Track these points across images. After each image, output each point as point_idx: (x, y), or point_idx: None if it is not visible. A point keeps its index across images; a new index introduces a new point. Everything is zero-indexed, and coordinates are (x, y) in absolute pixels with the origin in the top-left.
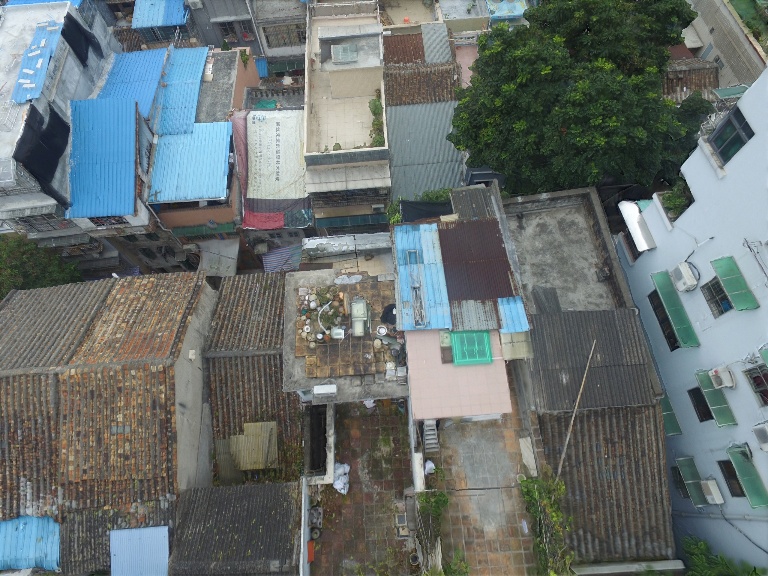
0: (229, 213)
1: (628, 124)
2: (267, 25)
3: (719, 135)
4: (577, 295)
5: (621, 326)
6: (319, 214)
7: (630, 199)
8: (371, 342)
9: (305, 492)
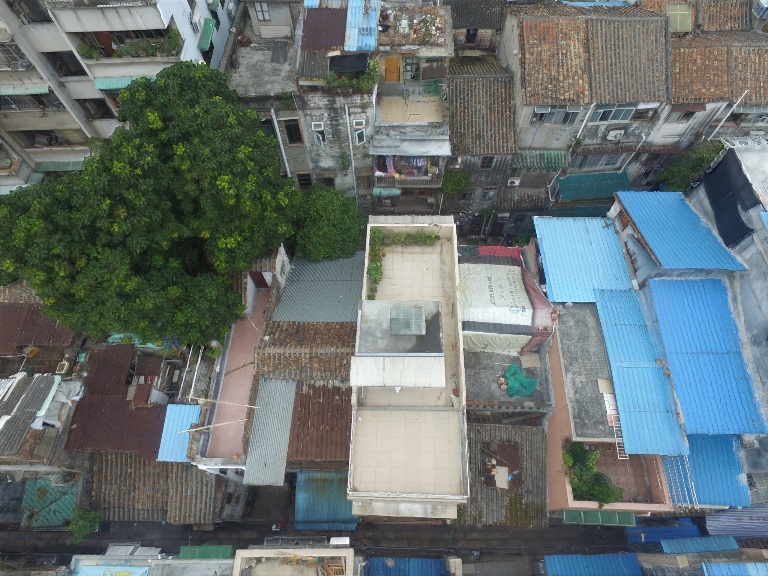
0: None
1: None
2: None
3: None
4: (258, 58)
5: None
6: None
7: None
8: (398, 18)
9: None
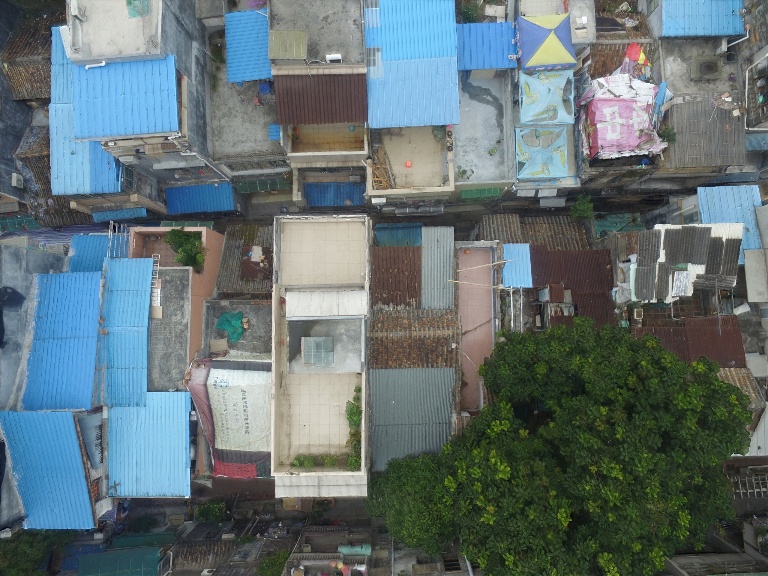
0: None
1: None
2: None
3: None
4: None
5: None
6: None
7: None
8: None
9: None
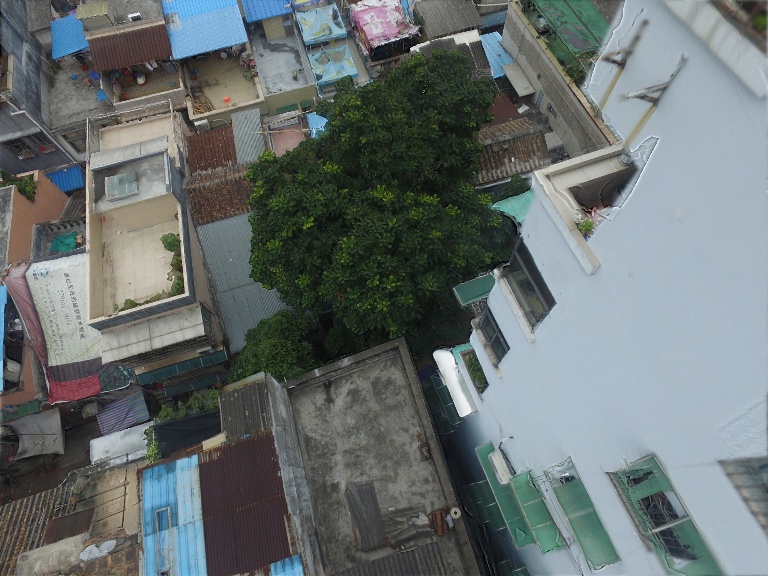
0: (25, 395)
1: (415, 273)
2: (66, 132)
3: (486, 325)
4: (398, 486)
5: (425, 571)
6: (139, 369)
7: None
8: None
9: None
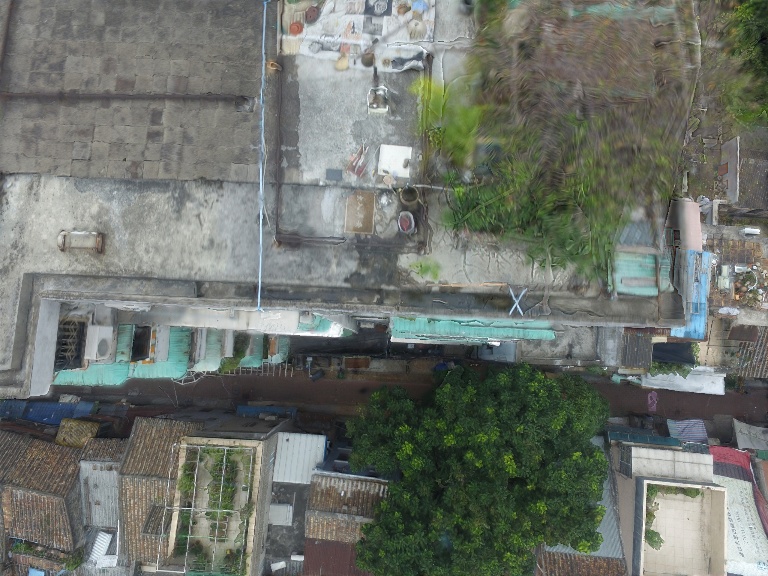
0: None
1: (510, 391)
2: None
3: None
4: None
5: None
6: None
7: (344, 441)
8: None
9: (733, 196)
